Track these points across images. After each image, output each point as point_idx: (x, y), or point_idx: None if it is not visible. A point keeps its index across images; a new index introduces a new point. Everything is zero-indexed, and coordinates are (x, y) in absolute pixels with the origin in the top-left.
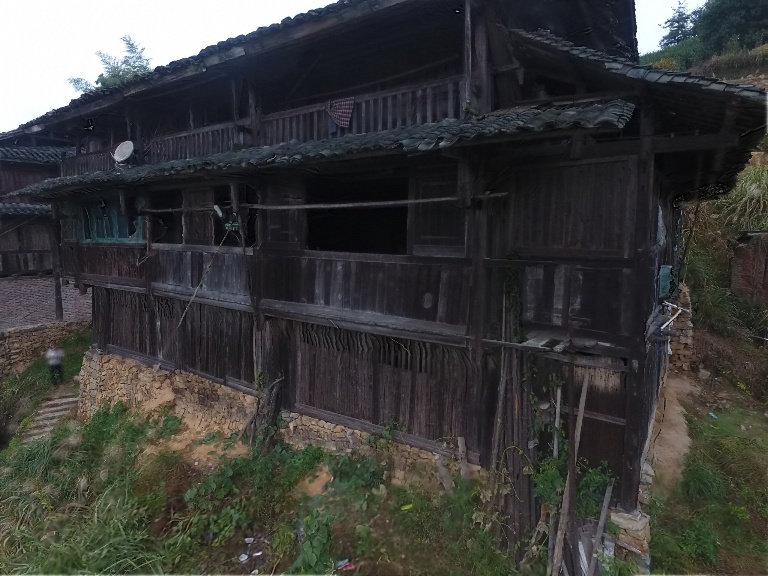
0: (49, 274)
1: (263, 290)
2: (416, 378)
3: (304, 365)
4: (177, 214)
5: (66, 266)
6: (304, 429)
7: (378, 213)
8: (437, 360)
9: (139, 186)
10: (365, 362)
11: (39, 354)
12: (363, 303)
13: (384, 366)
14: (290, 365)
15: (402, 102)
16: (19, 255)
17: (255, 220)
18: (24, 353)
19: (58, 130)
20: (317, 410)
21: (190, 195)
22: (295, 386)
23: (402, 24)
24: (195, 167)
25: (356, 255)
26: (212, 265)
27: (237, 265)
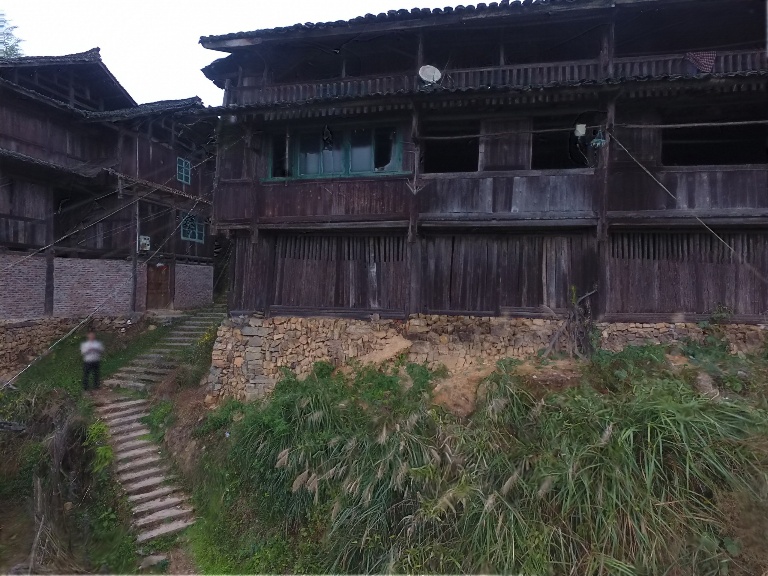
0: (40, 252)
1: (609, 203)
2: (739, 269)
3: (614, 277)
4: (473, 143)
5: (220, 211)
6: (619, 334)
7: (765, 130)
8: (758, 252)
9: (428, 112)
10: (686, 264)
11: (26, 359)
12: (733, 202)
13: (707, 264)
14: (598, 279)
15: (760, 59)
16: (9, 221)
17: (575, 149)
18: (7, 357)
19: (263, 50)
20: (633, 314)
21: (495, 124)
22: (605, 297)
23: (763, 7)
24: (621, 79)
25: (723, 166)
26: (529, 188)
27: (569, 185)
